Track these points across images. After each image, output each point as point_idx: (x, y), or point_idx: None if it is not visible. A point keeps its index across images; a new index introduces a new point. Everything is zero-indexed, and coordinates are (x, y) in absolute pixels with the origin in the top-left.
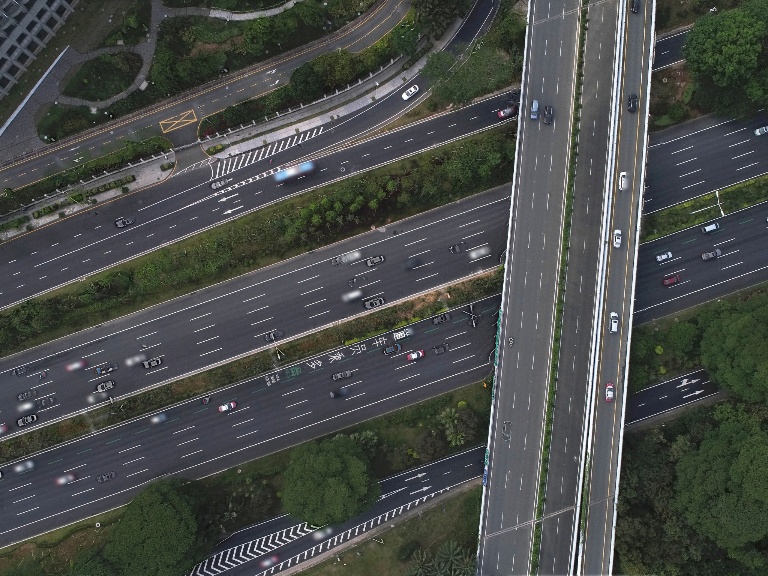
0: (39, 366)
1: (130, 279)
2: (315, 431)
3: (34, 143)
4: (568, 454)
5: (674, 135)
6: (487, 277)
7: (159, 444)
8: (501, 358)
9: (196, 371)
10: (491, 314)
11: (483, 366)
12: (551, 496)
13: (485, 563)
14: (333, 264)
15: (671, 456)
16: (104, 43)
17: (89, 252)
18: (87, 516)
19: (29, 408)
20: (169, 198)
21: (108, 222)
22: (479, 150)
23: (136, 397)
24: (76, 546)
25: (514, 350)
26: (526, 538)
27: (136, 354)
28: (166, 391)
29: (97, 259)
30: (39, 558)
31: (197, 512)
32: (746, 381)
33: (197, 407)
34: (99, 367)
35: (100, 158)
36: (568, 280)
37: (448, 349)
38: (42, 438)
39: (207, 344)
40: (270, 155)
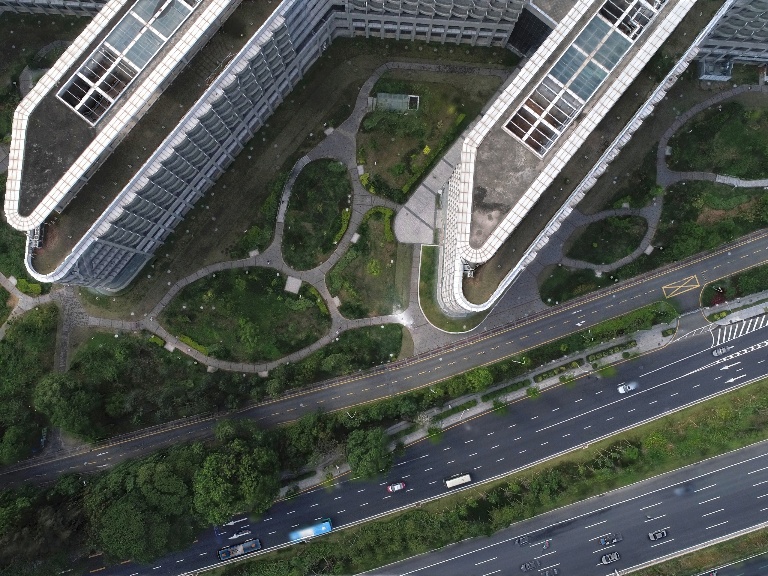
0: (542, 536)
1: (639, 449)
2: None
3: (536, 305)
4: None
5: None
6: None
7: None
8: None
9: (702, 544)
10: None
11: None
12: None
13: None
14: None
15: None
16: (610, 206)
17: (591, 418)
18: None
19: None
20: (670, 364)
21: (609, 388)
22: None
23: (647, 572)
24: None
25: None
26: None
27: (641, 525)
28: (676, 566)
29: (599, 426)
30: None
31: None
32: None
33: None
34: (603, 538)
35: (603, 322)
36: None
37: None
38: None
39: (713, 517)
40: None
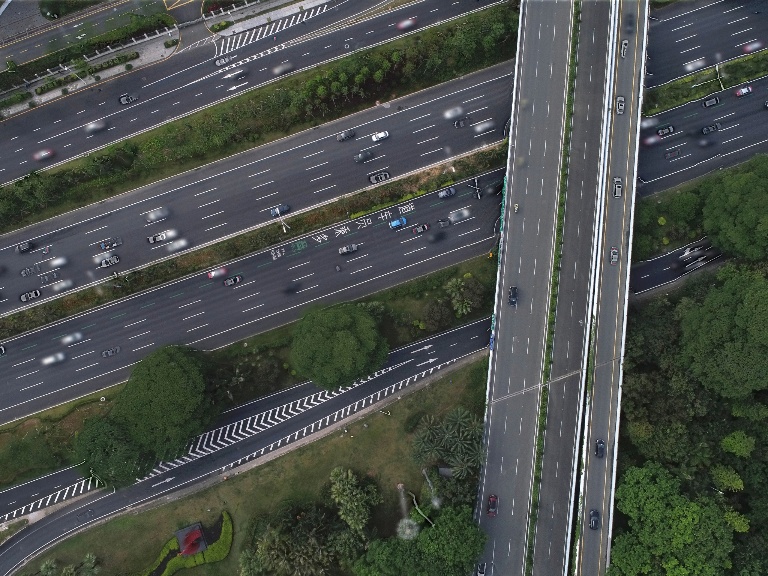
0: (42, 242)
1: (134, 153)
2: (321, 304)
3: (36, 20)
4: (574, 318)
5: (674, 12)
6: (491, 150)
7: (164, 318)
8: (507, 224)
9: (201, 246)
10: (496, 185)
11: (488, 239)
12: (557, 360)
13: (493, 427)
14: (338, 139)
15: (676, 315)
16: None
17: (93, 128)
18: (92, 391)
19: (32, 284)
20: (173, 75)
21: (112, 99)
22: (483, 21)
23: (141, 271)
24: (81, 420)
25: (519, 216)
26: (533, 402)
27: (141, 229)
28: (171, 265)
29: (101, 135)
30: (43, 431)
31: (204, 373)
32: (749, 237)
33: (202, 281)
34: (103, 242)
35: (103, 35)
36: (572, 146)
37: (453, 222)
38: (46, 311)
39: (212, 219)
40: (274, 32)
